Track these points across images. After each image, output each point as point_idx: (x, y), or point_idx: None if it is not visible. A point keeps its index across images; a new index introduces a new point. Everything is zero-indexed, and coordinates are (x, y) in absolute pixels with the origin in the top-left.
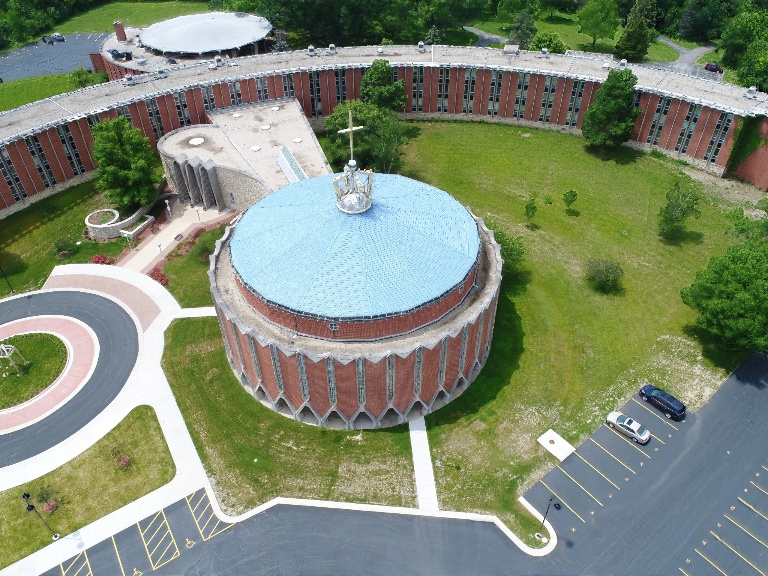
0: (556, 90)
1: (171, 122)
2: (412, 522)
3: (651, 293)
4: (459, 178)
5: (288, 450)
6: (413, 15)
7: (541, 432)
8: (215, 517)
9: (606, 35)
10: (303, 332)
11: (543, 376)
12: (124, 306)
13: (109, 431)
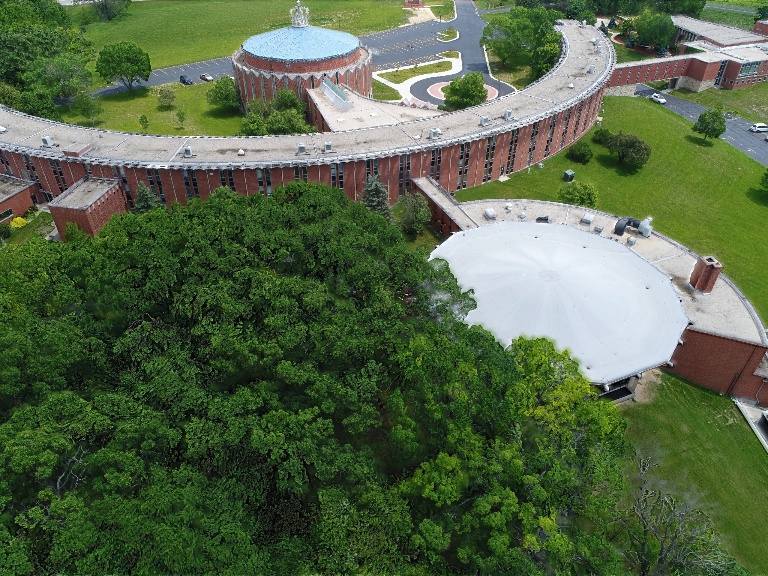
0: None
1: None
2: None
3: None
4: None
5: None
6: None
7: None
8: None
9: None
10: None
11: None
12: None
13: None
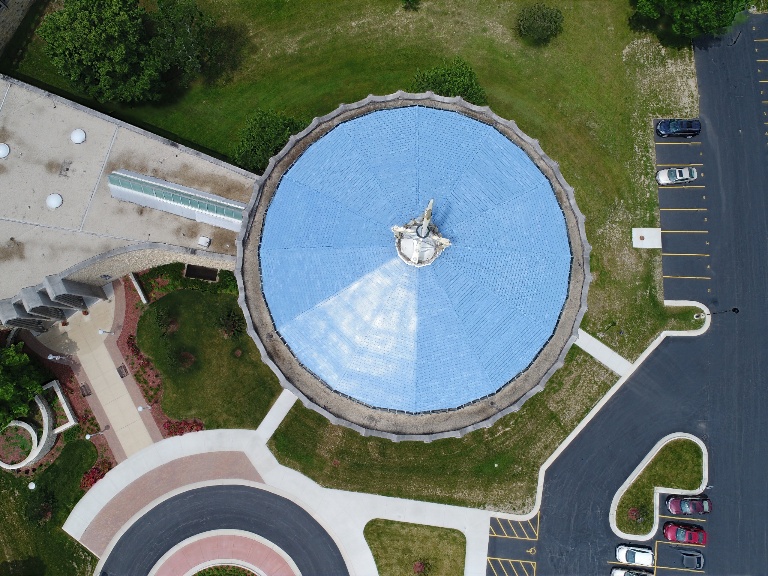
0: None
1: None
2: (627, 389)
3: (577, 4)
4: None
5: (506, 436)
6: None
7: (630, 238)
8: (523, 523)
9: None
10: None
11: (587, 186)
12: (204, 484)
13: (376, 567)
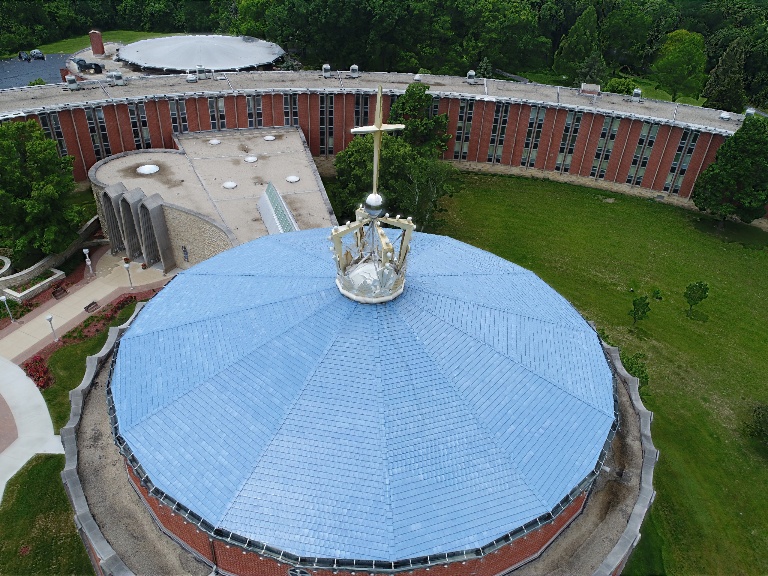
0: (655, 143)
1: (122, 143)
2: None
3: None
4: (520, 251)
5: None
6: (457, 50)
7: None
8: None
9: (691, 93)
10: (230, 570)
11: None
12: None
13: None
